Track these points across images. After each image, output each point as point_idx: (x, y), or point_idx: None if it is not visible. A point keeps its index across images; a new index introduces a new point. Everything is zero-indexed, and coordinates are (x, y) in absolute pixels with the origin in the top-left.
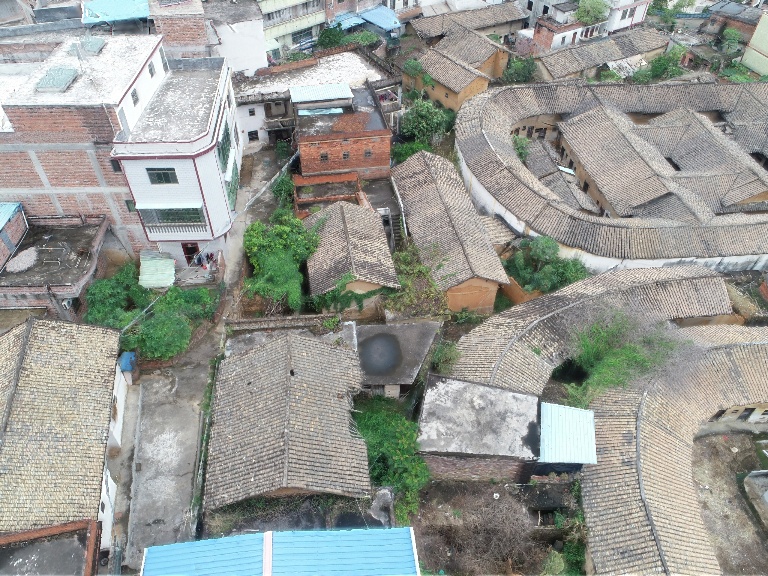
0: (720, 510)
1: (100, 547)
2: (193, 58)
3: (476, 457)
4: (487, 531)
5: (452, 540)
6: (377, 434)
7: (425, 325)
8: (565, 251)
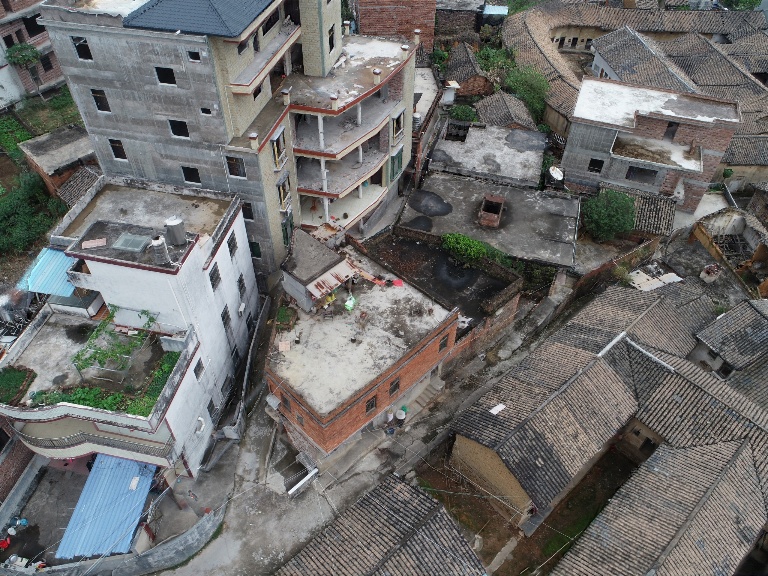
0: (568, 65)
1: None
2: None
3: (458, 11)
4: (462, 41)
5: None
6: None
7: None
8: None
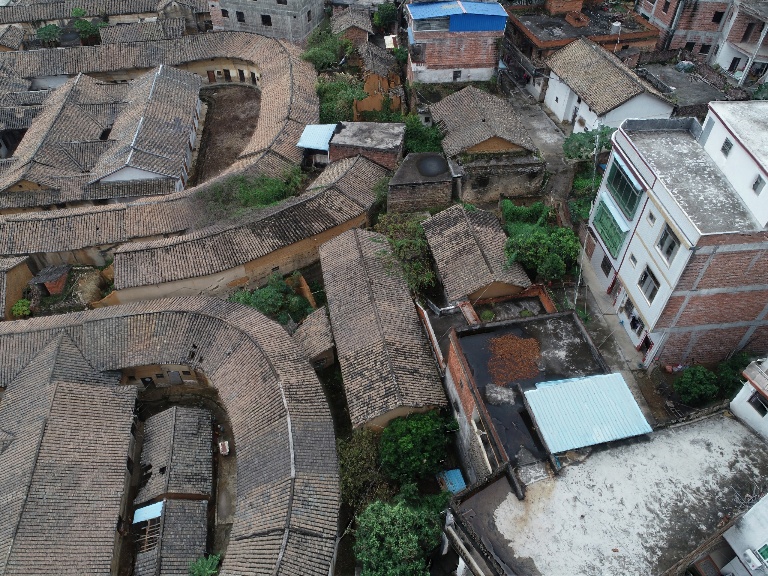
0: None
1: (548, 93)
2: None
3: None
4: None
5: None
6: (428, 146)
7: (400, 182)
8: None
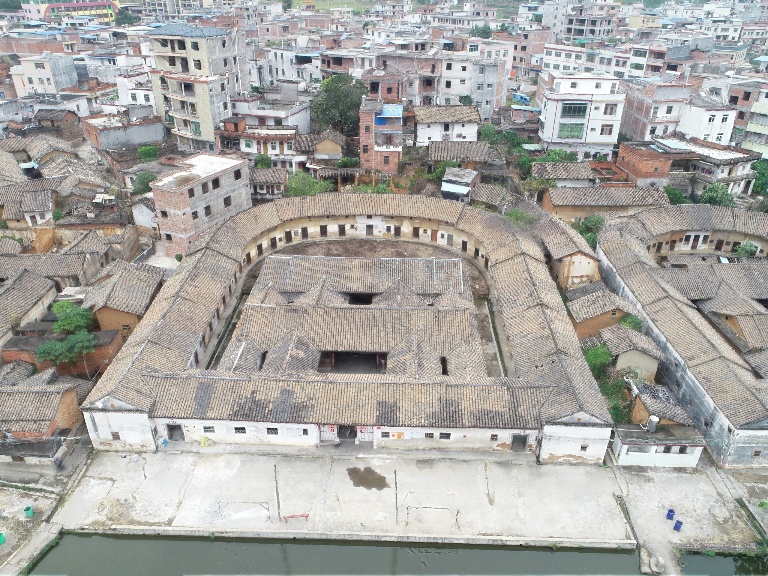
0: None
1: (419, 140)
2: (648, 106)
3: None
4: None
5: None
6: None
7: None
8: None
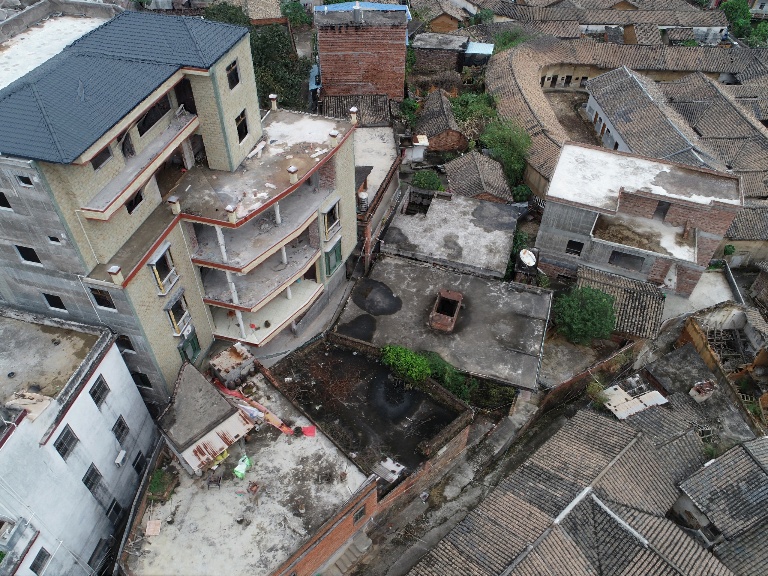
0: (560, 107)
1: None
2: None
3: (437, 49)
4: (442, 83)
5: (426, 90)
6: None
7: (417, 22)
8: (498, 20)
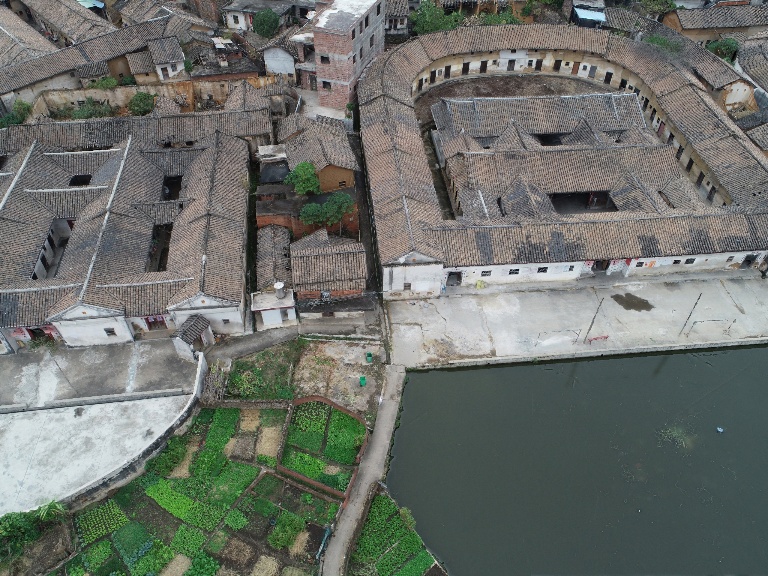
0: None
1: None
2: None
3: None
4: None
5: None
6: None
7: None
8: None
